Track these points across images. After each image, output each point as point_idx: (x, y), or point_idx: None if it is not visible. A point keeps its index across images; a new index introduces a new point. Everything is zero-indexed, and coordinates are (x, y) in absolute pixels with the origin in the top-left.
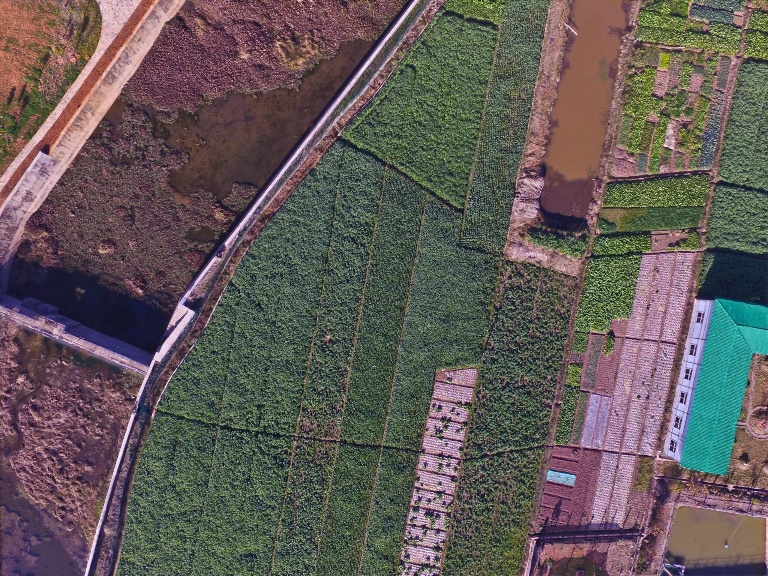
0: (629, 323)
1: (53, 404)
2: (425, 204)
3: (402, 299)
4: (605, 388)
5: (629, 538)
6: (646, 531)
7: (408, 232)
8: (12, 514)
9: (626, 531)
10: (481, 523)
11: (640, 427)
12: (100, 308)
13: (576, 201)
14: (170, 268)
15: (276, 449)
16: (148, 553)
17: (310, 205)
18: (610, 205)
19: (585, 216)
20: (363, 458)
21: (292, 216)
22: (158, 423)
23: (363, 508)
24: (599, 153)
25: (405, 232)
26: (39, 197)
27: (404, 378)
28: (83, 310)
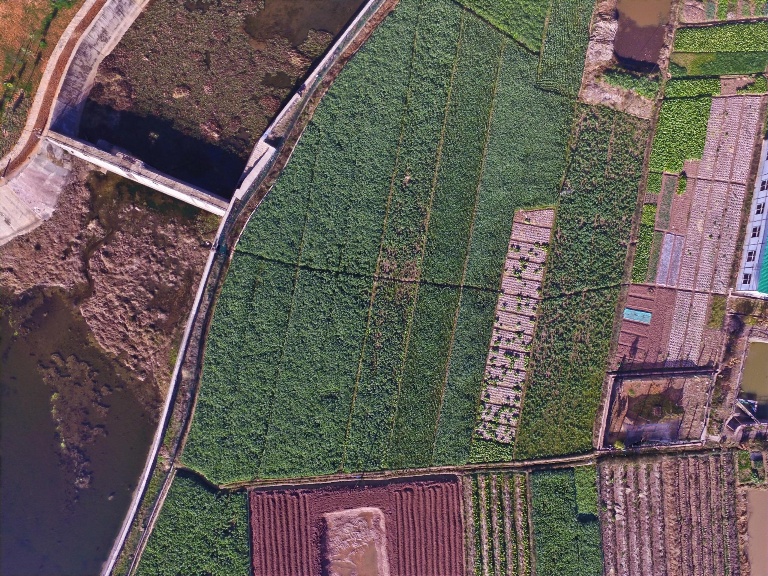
0: (700, 164)
1: (125, 250)
2: (502, 47)
3: (481, 140)
4: (678, 228)
5: (704, 374)
6: (720, 367)
7: (486, 73)
8: (82, 364)
9: (701, 368)
10: (560, 362)
11: (712, 266)
12: (174, 153)
13: (648, 46)
14: (246, 113)
15: (356, 289)
16: (227, 394)
17: (390, 45)
18: (681, 50)
19: (657, 61)
20: (443, 297)
21: (372, 56)
22: (237, 263)
23: (443, 348)
24: (669, 0)
25: (483, 74)
26: (113, 39)
27: (484, 217)
28: (157, 155)
